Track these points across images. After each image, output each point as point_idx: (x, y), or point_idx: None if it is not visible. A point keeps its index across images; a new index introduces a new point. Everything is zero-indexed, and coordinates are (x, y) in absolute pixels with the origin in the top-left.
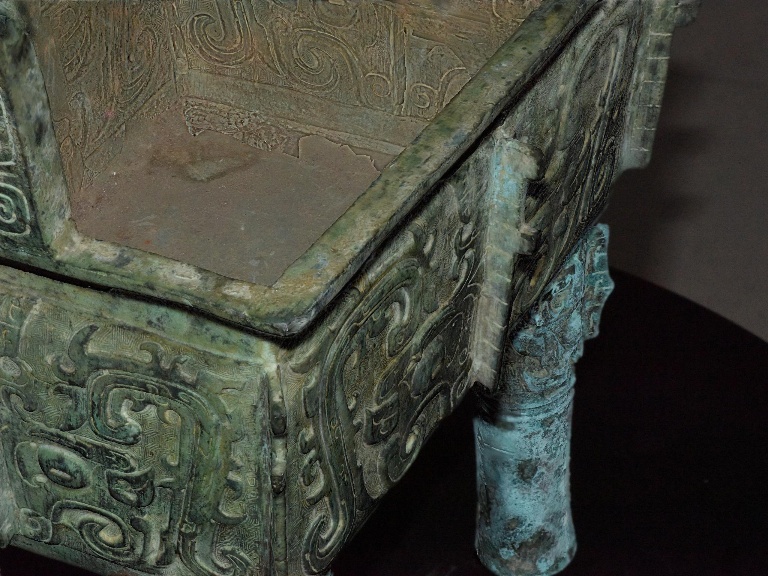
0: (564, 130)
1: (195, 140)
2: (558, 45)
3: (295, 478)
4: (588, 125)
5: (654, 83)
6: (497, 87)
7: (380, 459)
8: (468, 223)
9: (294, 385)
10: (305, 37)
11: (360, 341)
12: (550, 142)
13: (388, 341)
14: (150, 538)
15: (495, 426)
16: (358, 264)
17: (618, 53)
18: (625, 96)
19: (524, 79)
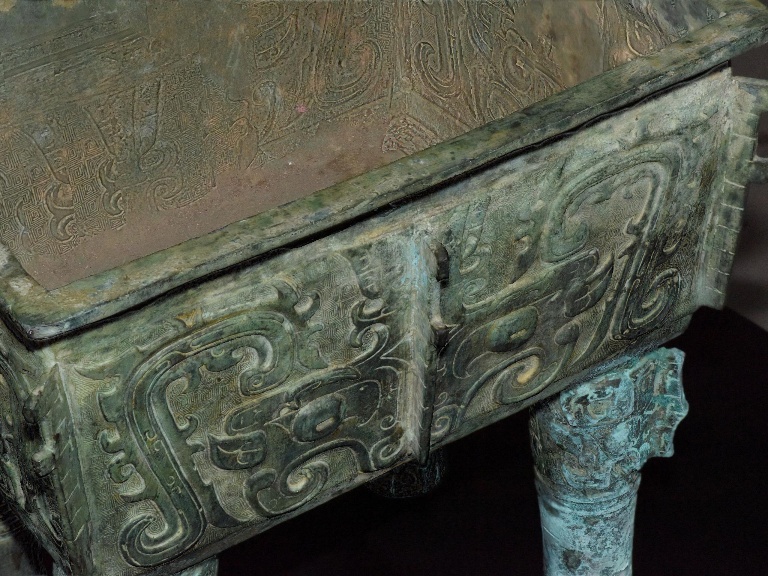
0: (547, 244)
1: (381, 156)
2: (493, 159)
3: (101, 472)
4: (608, 248)
5: (728, 229)
6: (396, 180)
7: (245, 486)
8: (378, 299)
9: (85, 387)
10: (496, 90)
11: (190, 370)
12: (525, 250)
13: (240, 380)
14: (16, 483)
15: (545, 507)
16: (142, 297)
17: (660, 188)
18: (693, 233)
19: (429, 180)
